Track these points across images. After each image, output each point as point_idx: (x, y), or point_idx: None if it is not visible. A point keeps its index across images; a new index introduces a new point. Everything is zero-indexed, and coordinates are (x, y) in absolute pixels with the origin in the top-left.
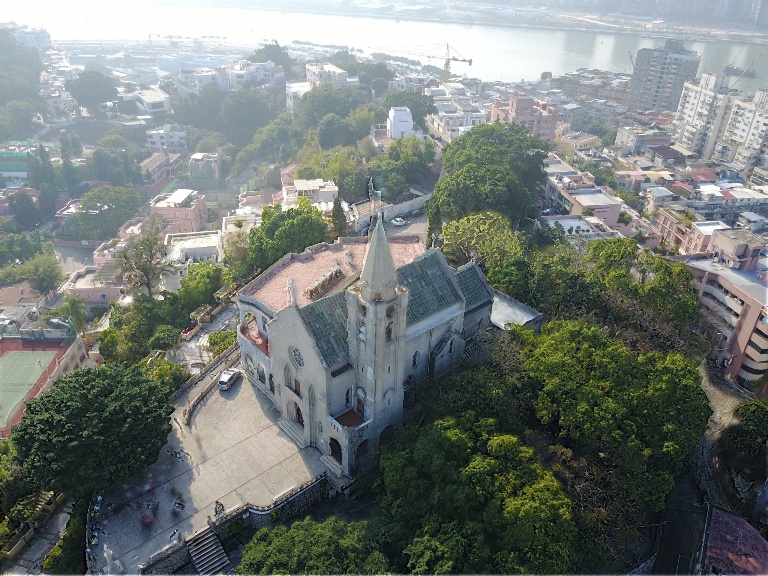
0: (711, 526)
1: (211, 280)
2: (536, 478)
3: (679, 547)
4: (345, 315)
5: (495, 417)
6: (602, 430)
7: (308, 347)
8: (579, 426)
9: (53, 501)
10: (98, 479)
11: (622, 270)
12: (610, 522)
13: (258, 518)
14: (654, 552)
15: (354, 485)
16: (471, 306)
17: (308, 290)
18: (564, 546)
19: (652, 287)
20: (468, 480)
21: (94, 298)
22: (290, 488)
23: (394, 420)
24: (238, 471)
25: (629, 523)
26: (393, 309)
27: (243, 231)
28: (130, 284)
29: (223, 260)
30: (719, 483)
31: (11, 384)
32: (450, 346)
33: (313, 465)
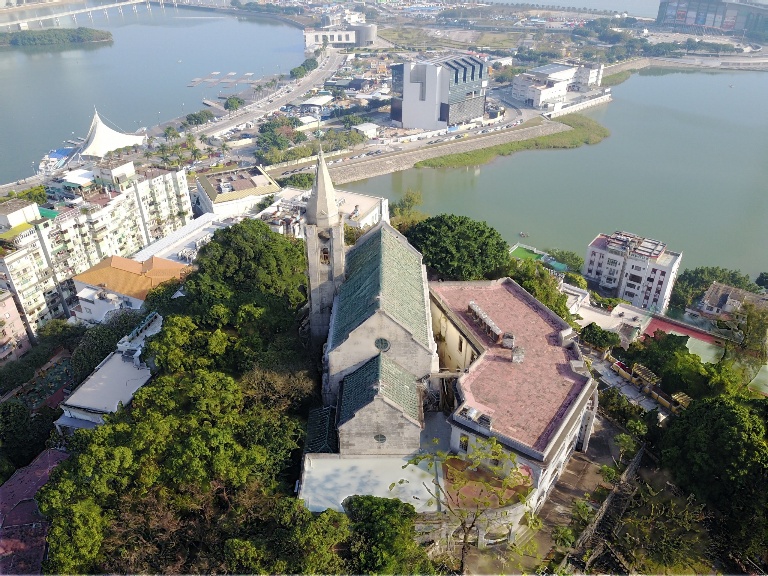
0: (40, 568)
1: None
2: None
3: None
4: None
5: None
6: None
7: None
8: None
9: None
10: None
11: None
12: None
13: None
14: None
15: None
16: None
17: None
18: None
19: None
20: None
21: None
22: None
23: None
24: None
25: None
26: None
27: None
28: None
29: None
30: None
31: None
32: None
33: None
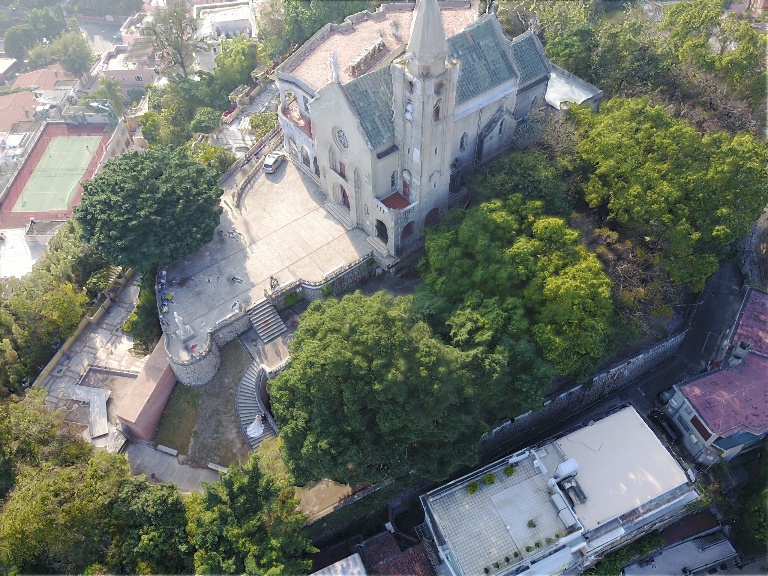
0: (747, 307)
1: (247, 58)
2: (579, 259)
3: (710, 325)
4: (390, 92)
5: (542, 200)
6: (652, 213)
7: (352, 127)
8: (628, 210)
9: (123, 275)
10: (160, 255)
11: (700, 39)
12: (647, 301)
13: (310, 292)
14: (685, 329)
15: (400, 264)
16: (525, 82)
17: (350, 66)
18: (600, 321)
19: (731, 59)
20: (511, 260)
21: (129, 81)
22: (339, 266)
23: (439, 203)
24: (289, 250)
25: (666, 302)
26: (442, 85)
27: (276, 0)
28: (164, 63)
29: (257, 35)
30: (762, 268)
31: (64, 169)
32: (500, 127)
33: (360, 245)
